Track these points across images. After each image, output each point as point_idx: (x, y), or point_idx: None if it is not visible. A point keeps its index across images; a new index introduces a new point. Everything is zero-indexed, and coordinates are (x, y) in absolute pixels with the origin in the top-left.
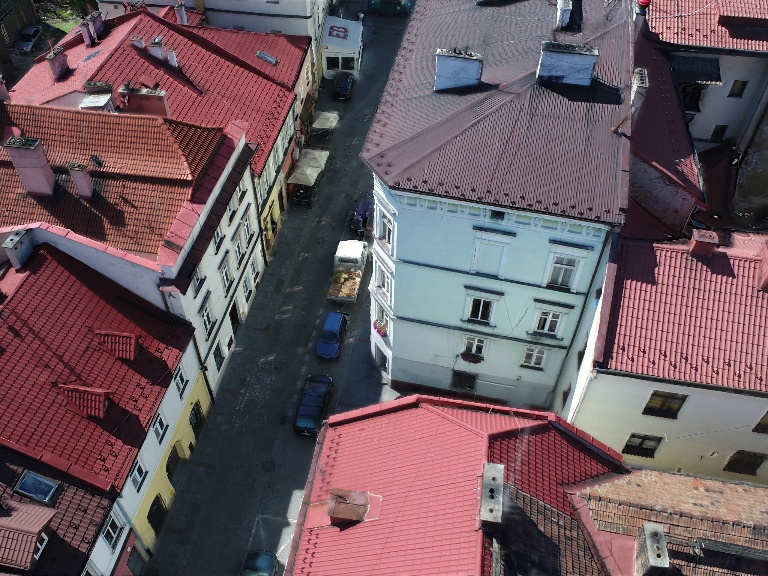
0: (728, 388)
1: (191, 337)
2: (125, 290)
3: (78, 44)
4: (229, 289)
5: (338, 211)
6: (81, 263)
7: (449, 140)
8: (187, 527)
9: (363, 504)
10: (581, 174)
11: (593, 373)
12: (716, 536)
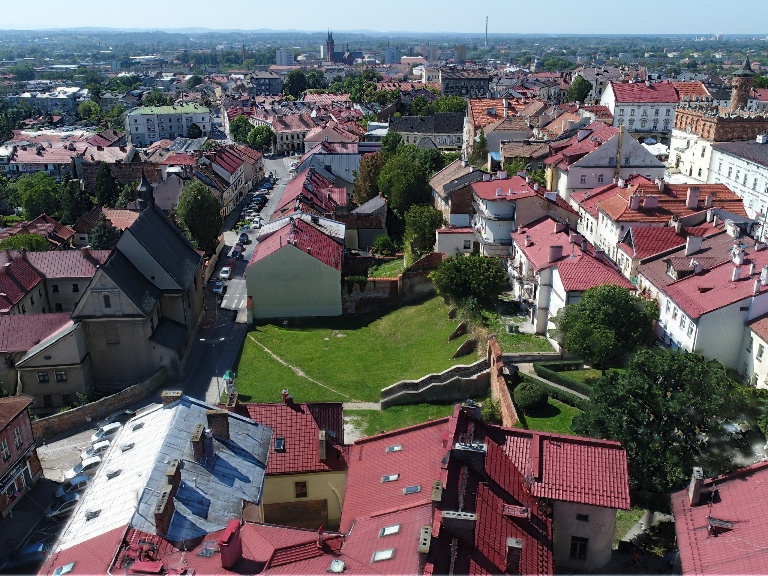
0: None
1: None
2: None
3: None
4: None
5: None
6: None
7: None
8: None
9: None
10: None
11: None
12: None
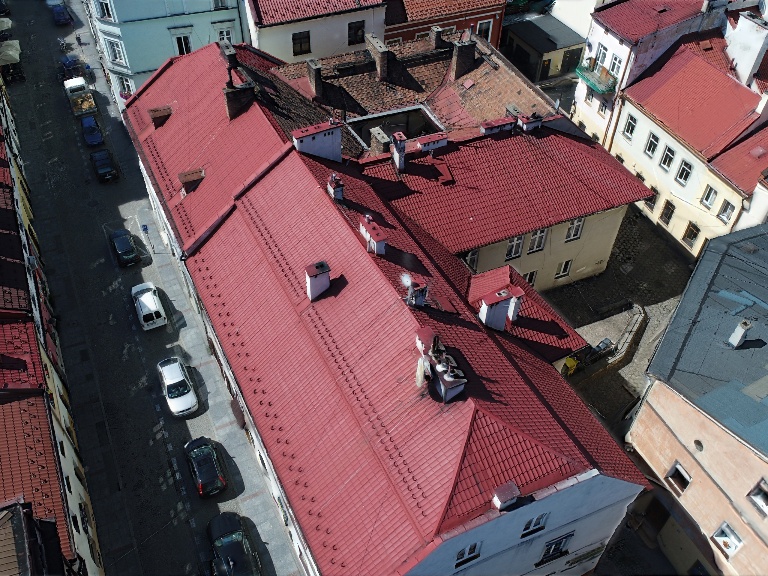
0: (323, 14)
1: (1, 119)
2: None
3: None
4: (3, 112)
5: (48, 77)
6: None
7: None
8: (58, 246)
9: (168, 108)
10: None
11: (257, 29)
12: (341, 63)
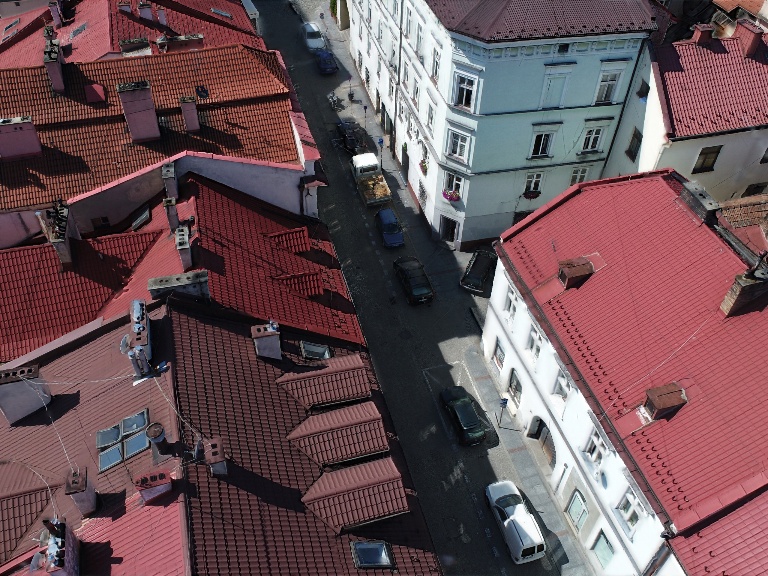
0: (752, 127)
1: None
2: (263, 203)
3: (32, 32)
4: None
5: (322, 142)
6: (222, 185)
7: (509, 0)
8: None
9: (586, 263)
10: (613, 3)
11: (669, 143)
12: None
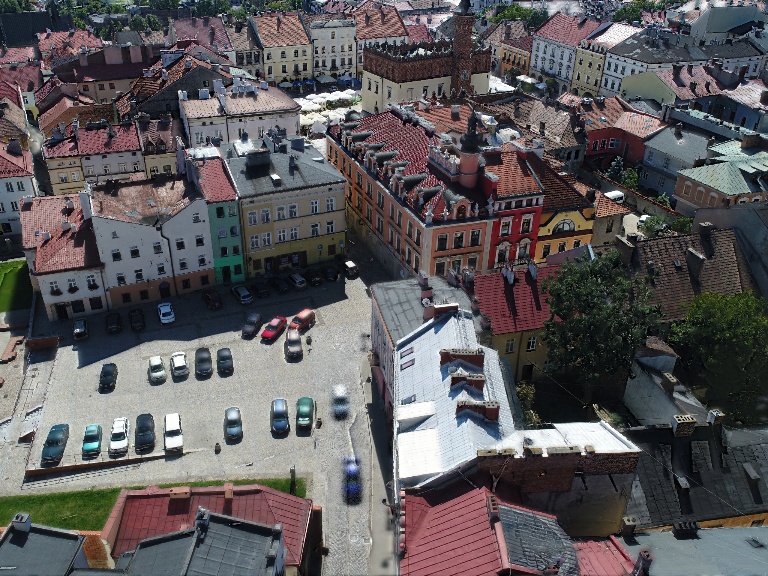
0: None
1: None
2: None
3: None
4: None
5: None
6: None
7: None
8: None
9: None
10: None
11: None
12: None
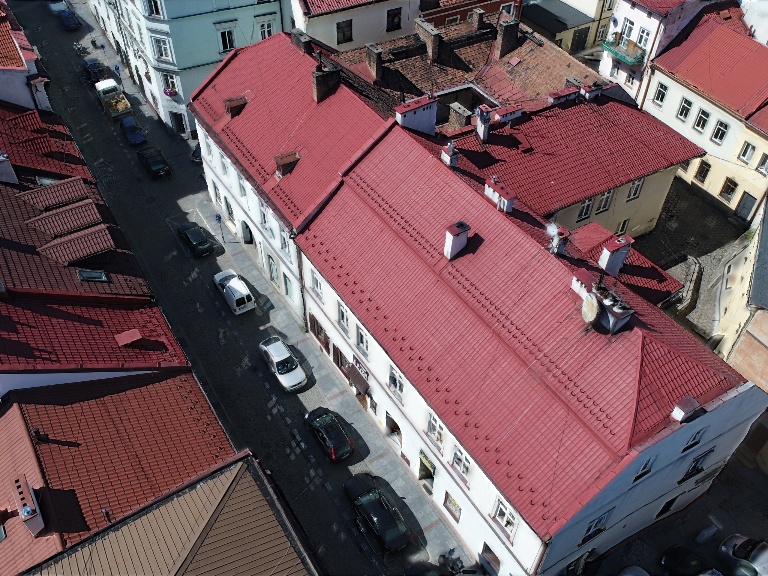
0: (366, 3)
1: None
2: (1, 101)
3: None
4: None
5: (71, 81)
6: None
7: None
8: None
9: (242, 98)
10: None
11: (307, 19)
12: (394, 47)
